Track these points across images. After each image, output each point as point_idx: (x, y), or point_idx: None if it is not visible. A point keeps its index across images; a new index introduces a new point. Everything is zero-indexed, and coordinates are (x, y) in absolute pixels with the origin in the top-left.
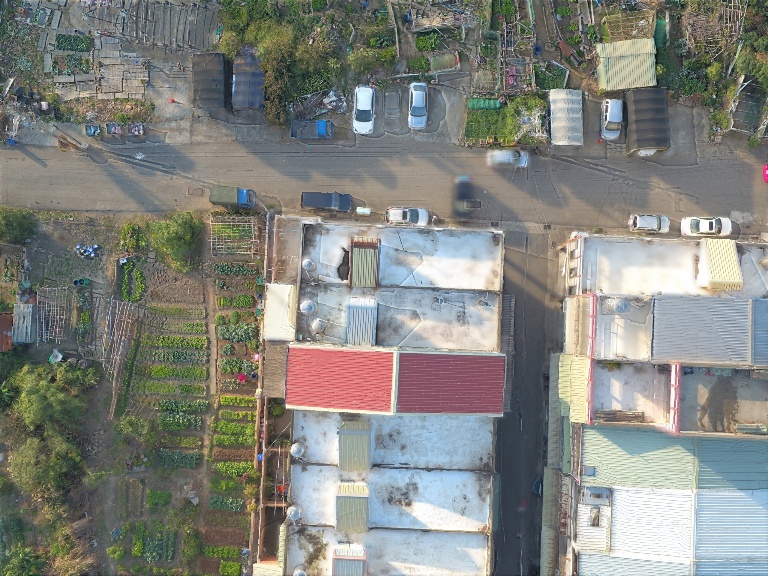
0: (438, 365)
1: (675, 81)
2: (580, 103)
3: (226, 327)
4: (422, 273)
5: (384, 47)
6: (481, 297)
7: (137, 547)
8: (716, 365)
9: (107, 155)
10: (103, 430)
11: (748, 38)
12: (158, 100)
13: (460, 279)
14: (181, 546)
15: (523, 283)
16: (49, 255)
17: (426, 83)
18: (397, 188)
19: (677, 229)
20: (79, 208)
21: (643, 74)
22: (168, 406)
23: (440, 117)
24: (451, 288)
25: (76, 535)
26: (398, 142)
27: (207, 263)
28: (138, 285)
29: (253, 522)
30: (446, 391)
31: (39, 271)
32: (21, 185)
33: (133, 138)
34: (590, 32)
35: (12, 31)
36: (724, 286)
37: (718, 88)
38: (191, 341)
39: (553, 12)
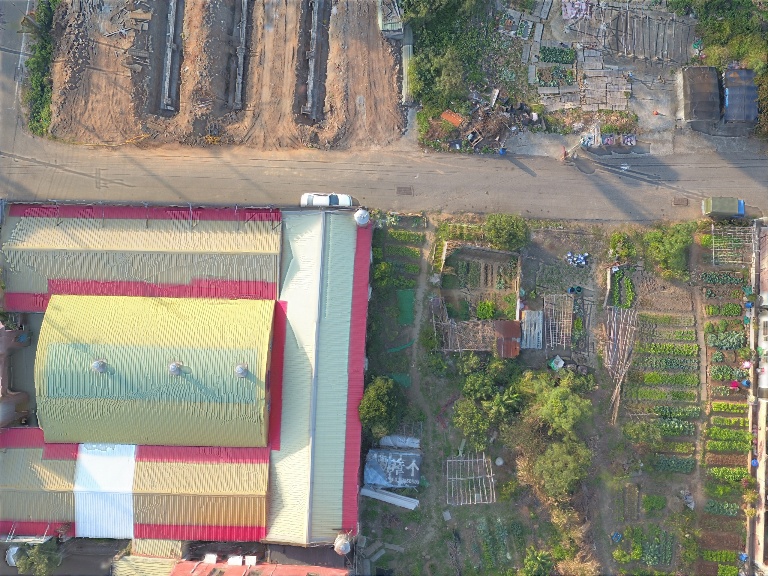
0: None
1: None
2: None
3: (715, 334)
4: None
5: None
6: None
7: (637, 551)
8: None
9: (594, 165)
10: (598, 435)
11: None
12: (641, 112)
13: None
14: (679, 550)
15: None
16: (540, 263)
17: None
18: None
19: None
20: (569, 217)
21: None
22: (662, 412)
23: None
24: None
25: (581, 538)
26: None
27: (694, 272)
28: (629, 293)
29: (749, 527)
30: None
31: (531, 278)
32: (512, 194)
33: (619, 149)
34: None
35: (496, 43)
36: None
37: None
38: (682, 348)
39: None
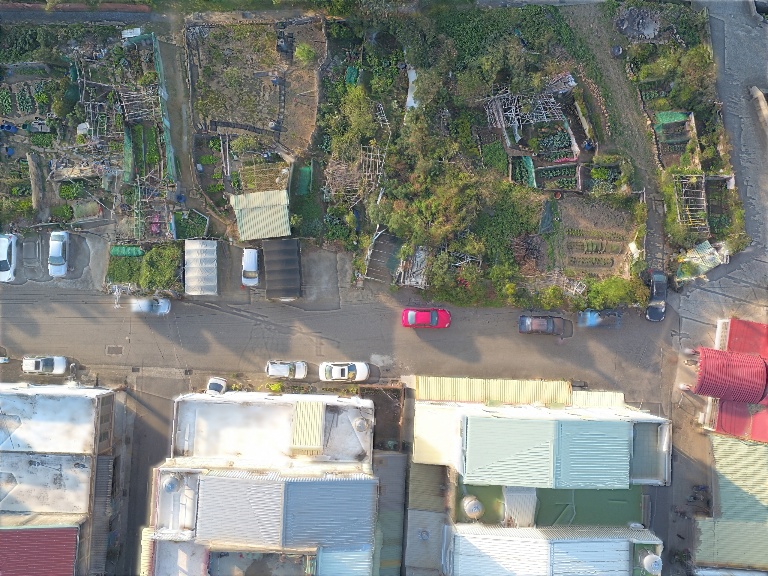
0: (2, 540)
1: (317, 228)
2: (214, 253)
3: None
4: (19, 436)
5: (27, 195)
6: (78, 459)
7: None
8: (244, 550)
9: None
10: None
11: (388, 186)
12: None
13: (58, 441)
14: None
15: (163, 428)
16: None
17: (70, 230)
18: (38, 335)
19: (317, 373)
20: None
21: (277, 224)
22: None
23: (84, 264)
24: (46, 452)
25: None
26: (41, 289)
27: None
28: None
29: None
30: (17, 563)
31: None
32: None
33: None
34: (233, 180)
35: None
36: (305, 452)
37: (361, 234)
38: None
39: (193, 162)
